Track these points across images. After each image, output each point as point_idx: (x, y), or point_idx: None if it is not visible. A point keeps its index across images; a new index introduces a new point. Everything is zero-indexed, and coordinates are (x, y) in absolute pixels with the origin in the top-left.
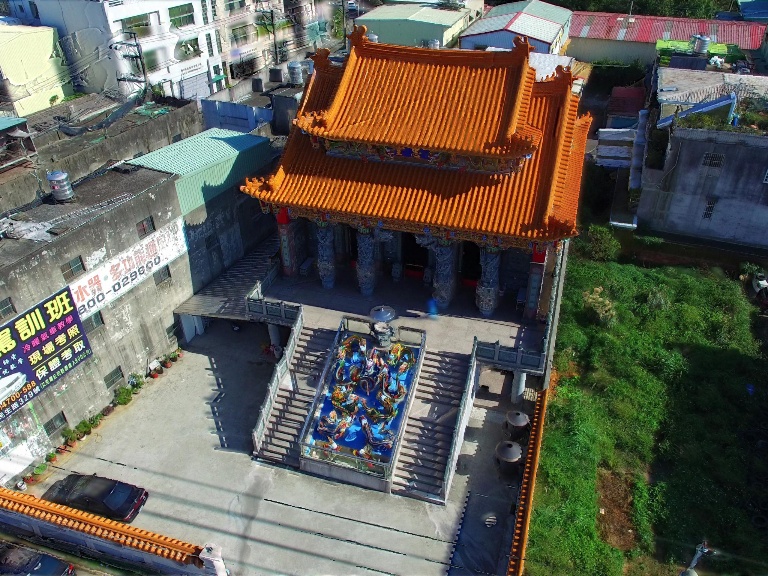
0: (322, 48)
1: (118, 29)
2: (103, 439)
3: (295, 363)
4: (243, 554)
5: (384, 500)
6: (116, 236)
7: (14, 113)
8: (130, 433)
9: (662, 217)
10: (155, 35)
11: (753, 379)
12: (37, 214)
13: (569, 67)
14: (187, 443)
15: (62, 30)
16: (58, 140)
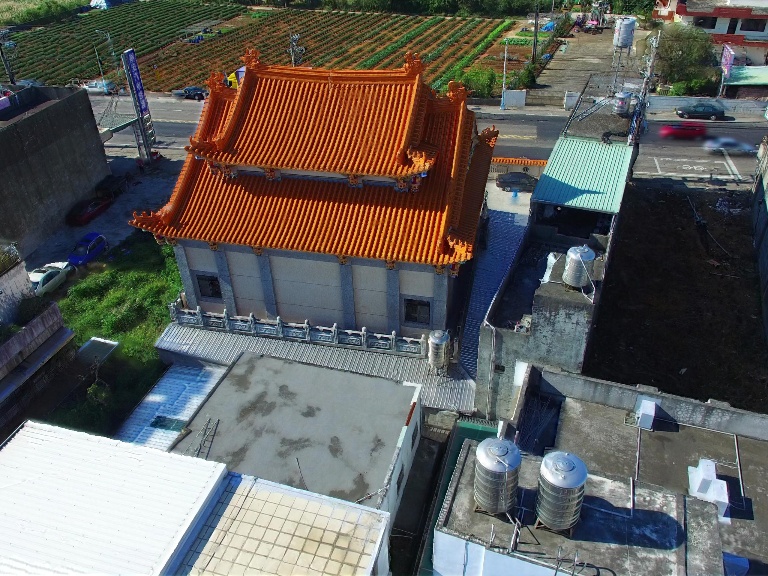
0: None
1: None
2: None
3: None
4: None
5: None
6: None
7: None
8: None
9: None
10: None
11: (117, 261)
12: None
13: None
14: (496, 208)
15: None
16: None
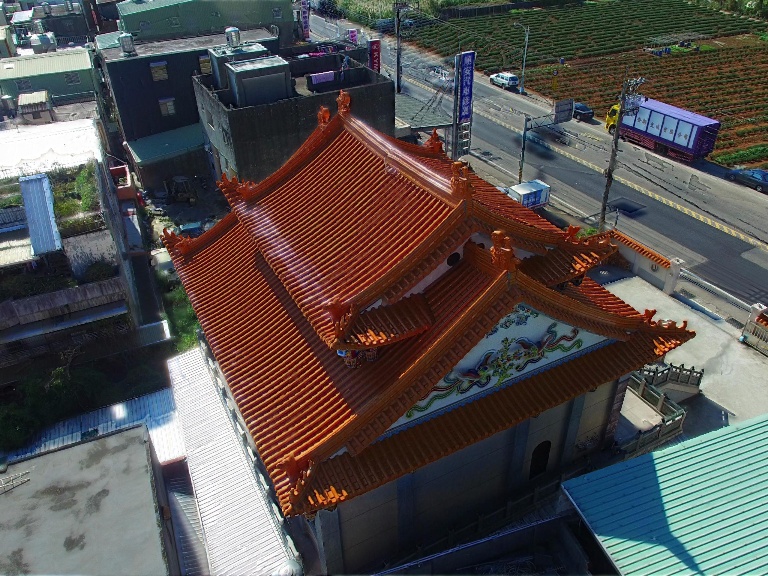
0: None
1: None
2: None
3: None
4: (727, 345)
5: None
6: None
7: None
8: None
9: None
10: None
11: None
12: None
13: None
14: None
15: None
16: None
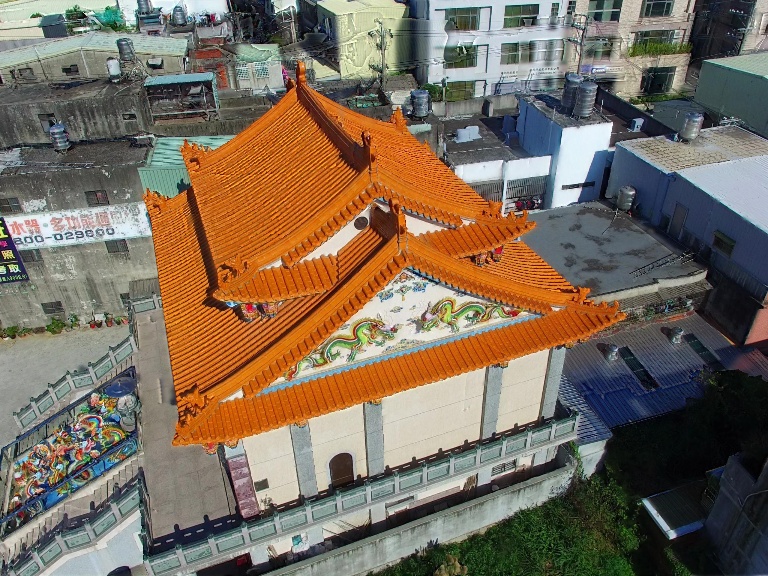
0: (681, 87)
1: (439, 18)
2: (11, 348)
3: (102, 383)
4: None
5: None
6: (60, 194)
7: (313, 74)
8: (23, 355)
9: (738, 559)
10: (426, 30)
11: None
12: (35, 153)
13: (398, 206)
14: (23, 390)
15: (415, 10)
16: (263, 105)
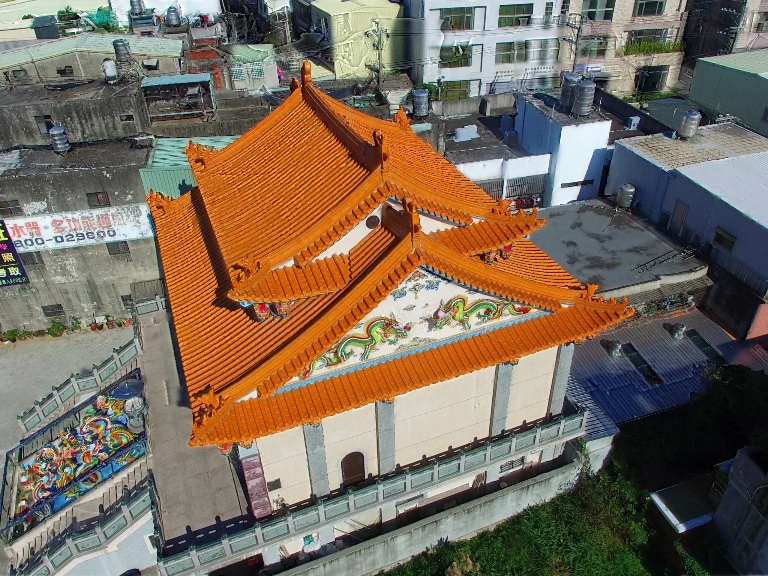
0: (674, 86)
1: (434, 17)
2: (11, 351)
3: (106, 386)
4: None
5: (0, 561)
6: (61, 196)
7: None
8: (24, 359)
9: (747, 551)
10: (422, 30)
11: None
12: (34, 155)
13: (412, 204)
14: (25, 393)
15: (409, 10)
16: (260, 105)
